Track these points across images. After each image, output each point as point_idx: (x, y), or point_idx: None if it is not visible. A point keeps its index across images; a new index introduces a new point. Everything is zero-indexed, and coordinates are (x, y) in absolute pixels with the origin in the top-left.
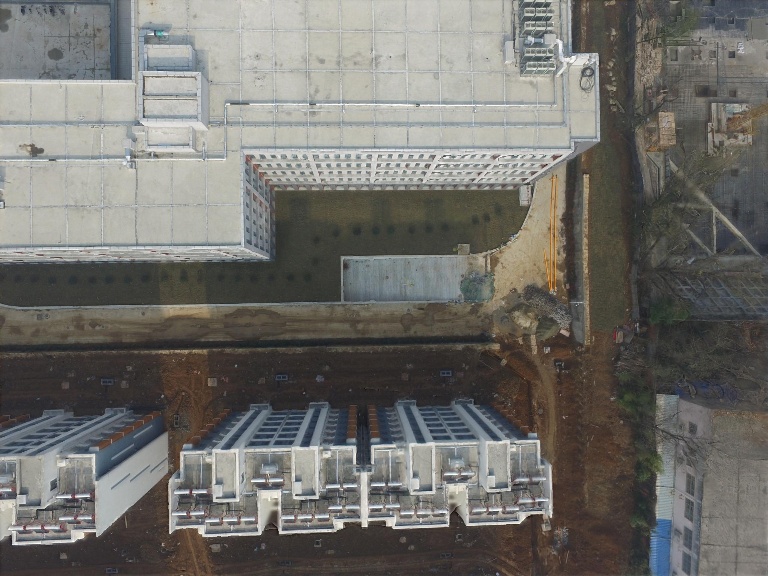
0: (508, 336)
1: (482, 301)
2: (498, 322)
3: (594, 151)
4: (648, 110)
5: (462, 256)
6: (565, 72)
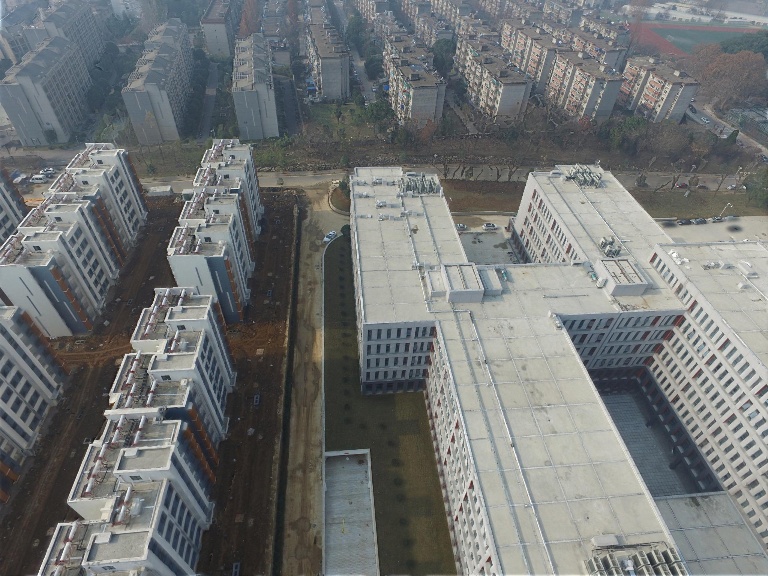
0: None
1: None
2: None
3: None
4: None
5: None
6: None
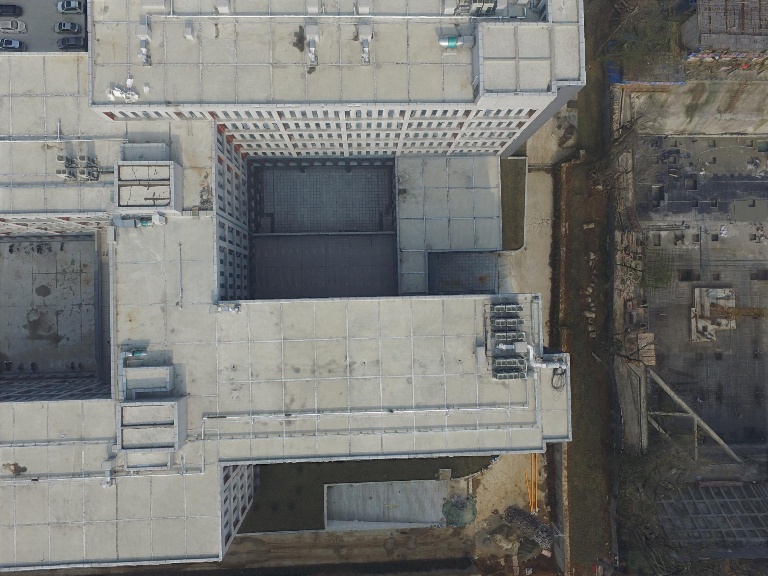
0: (490, 557)
1: (464, 524)
2: (480, 544)
3: (573, 380)
4: (629, 321)
5: (444, 480)
6: (537, 371)
